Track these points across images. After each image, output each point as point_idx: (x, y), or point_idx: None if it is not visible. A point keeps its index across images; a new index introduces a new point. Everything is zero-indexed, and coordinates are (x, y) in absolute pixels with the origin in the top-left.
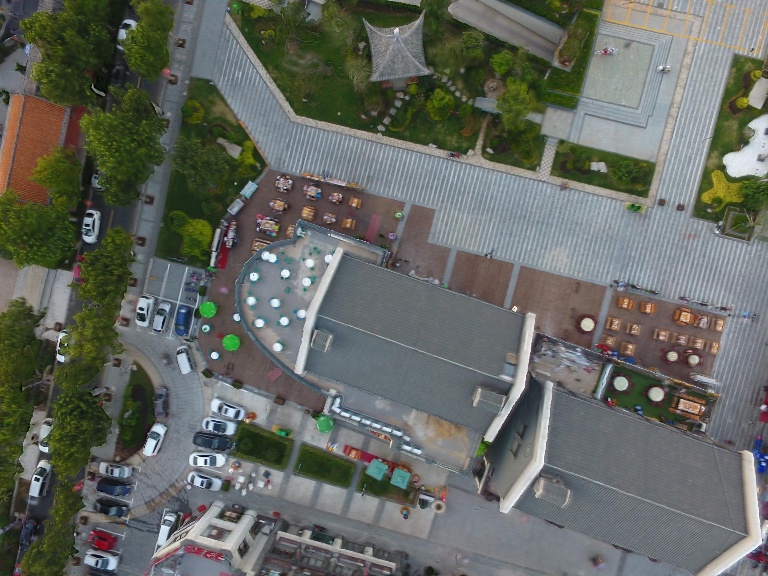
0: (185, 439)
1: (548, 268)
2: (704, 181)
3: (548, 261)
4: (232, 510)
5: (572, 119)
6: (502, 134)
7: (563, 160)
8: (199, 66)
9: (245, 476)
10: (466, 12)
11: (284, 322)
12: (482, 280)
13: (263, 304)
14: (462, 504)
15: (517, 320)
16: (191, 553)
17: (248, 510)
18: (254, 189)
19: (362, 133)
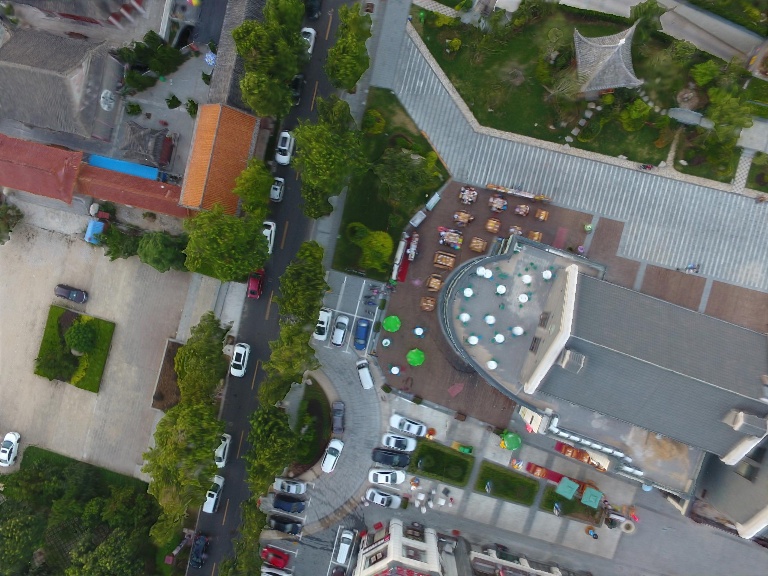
0: (361, 455)
1: (742, 283)
2: None
3: (742, 276)
4: (411, 528)
5: None
6: (700, 146)
7: (759, 172)
8: (379, 75)
9: (424, 493)
10: None
11: (499, 339)
12: (673, 295)
13: (475, 320)
14: (649, 524)
15: (761, 340)
16: (397, 575)
17: (427, 528)
18: (437, 201)
19: (548, 144)
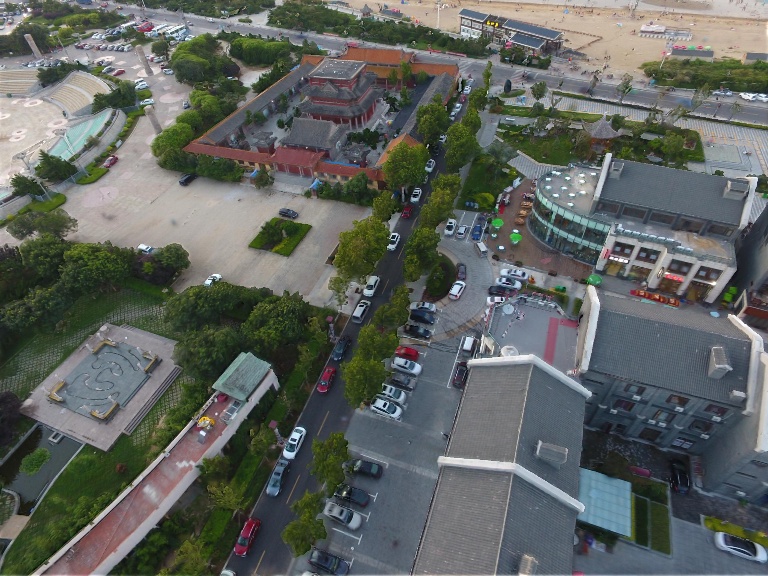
0: (479, 293)
1: None
2: None
3: None
4: None
5: (704, 166)
6: None
7: None
8: None
9: None
10: None
11: (572, 195)
12: None
13: (555, 191)
14: None
15: None
16: (523, 305)
17: None
18: (519, 184)
19: None
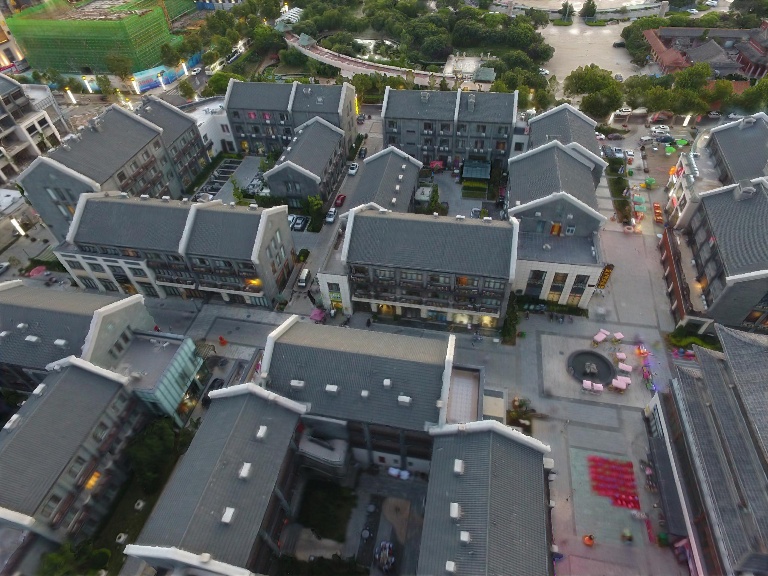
0: None
1: None
2: None
3: None
4: None
5: None
6: None
7: None
8: None
9: None
10: None
11: None
12: None
13: None
14: (634, 243)
15: None
16: None
17: None
18: None
19: None
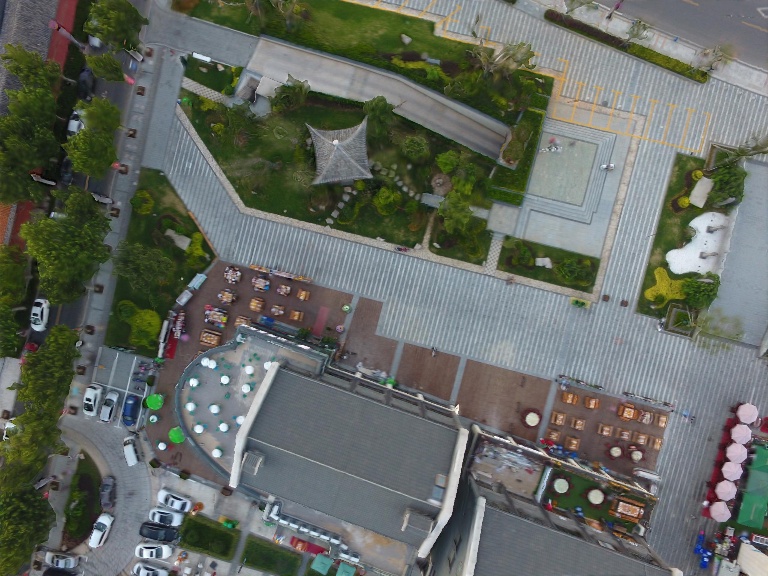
0: (132, 529)
1: (494, 362)
2: (647, 278)
3: (494, 355)
4: None
5: (517, 215)
6: None
7: (509, 255)
8: (149, 156)
9: (192, 567)
10: (414, 106)
11: (223, 428)
12: (429, 373)
13: (203, 409)
14: None
15: (450, 436)
16: None
17: None
18: (203, 280)
19: (311, 225)
